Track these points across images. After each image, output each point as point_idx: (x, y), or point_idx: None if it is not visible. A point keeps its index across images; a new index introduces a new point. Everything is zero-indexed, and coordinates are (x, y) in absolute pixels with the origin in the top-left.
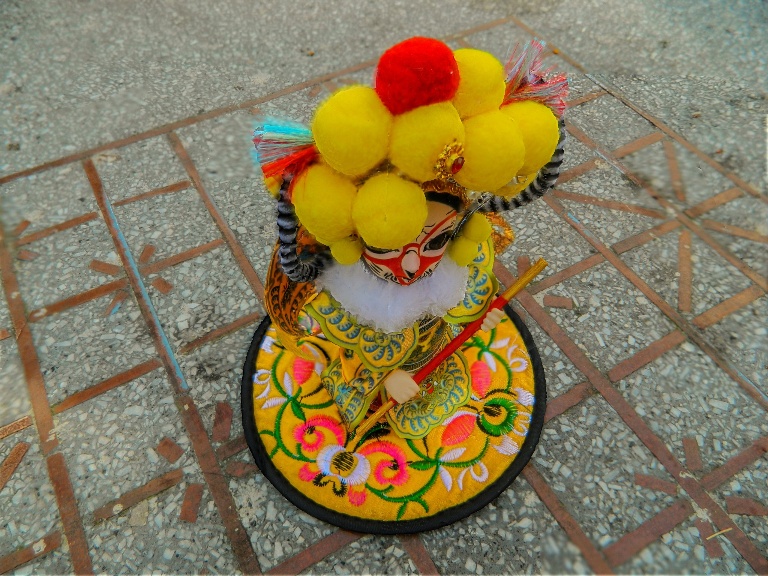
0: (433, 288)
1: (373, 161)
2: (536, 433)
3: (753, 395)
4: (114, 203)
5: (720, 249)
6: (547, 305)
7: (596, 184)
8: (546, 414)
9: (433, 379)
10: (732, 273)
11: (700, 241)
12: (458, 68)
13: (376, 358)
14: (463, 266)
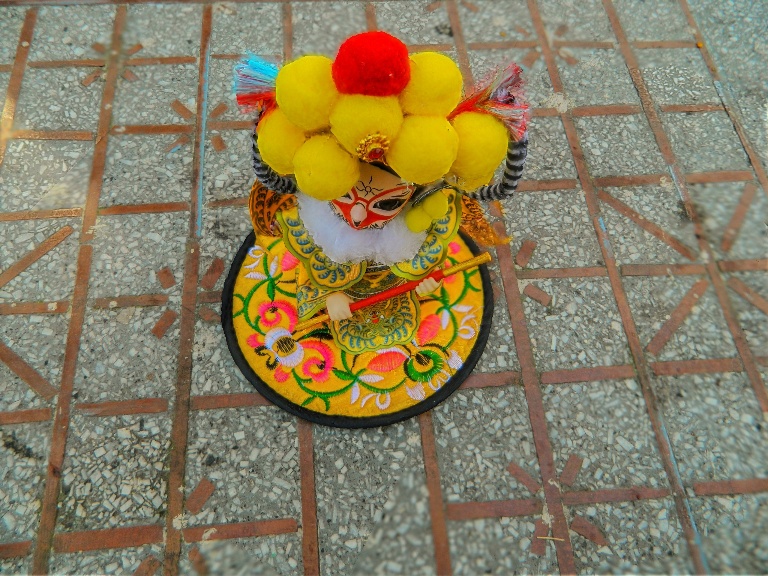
0: (380, 240)
1: (313, 124)
2: (446, 393)
3: (662, 450)
4: (213, 55)
5: (728, 311)
6: (526, 293)
7: (647, 200)
8: (467, 382)
9: (381, 313)
10: (723, 338)
11: (713, 296)
12: (413, 69)
13: (321, 276)
14: (416, 232)
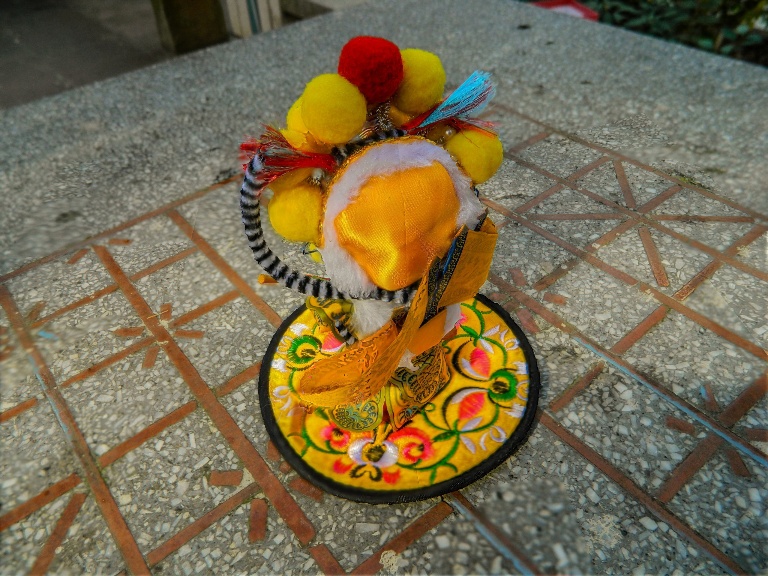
0: None
1: None
2: (274, 338)
3: (68, 412)
4: None
5: None
6: (240, 471)
7: None
8: None
9: None
10: None
11: None
12: None
13: None
14: None
